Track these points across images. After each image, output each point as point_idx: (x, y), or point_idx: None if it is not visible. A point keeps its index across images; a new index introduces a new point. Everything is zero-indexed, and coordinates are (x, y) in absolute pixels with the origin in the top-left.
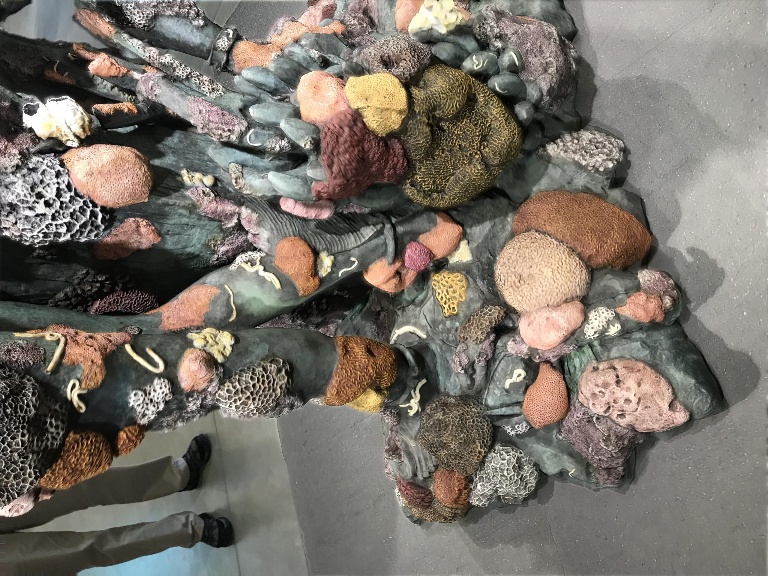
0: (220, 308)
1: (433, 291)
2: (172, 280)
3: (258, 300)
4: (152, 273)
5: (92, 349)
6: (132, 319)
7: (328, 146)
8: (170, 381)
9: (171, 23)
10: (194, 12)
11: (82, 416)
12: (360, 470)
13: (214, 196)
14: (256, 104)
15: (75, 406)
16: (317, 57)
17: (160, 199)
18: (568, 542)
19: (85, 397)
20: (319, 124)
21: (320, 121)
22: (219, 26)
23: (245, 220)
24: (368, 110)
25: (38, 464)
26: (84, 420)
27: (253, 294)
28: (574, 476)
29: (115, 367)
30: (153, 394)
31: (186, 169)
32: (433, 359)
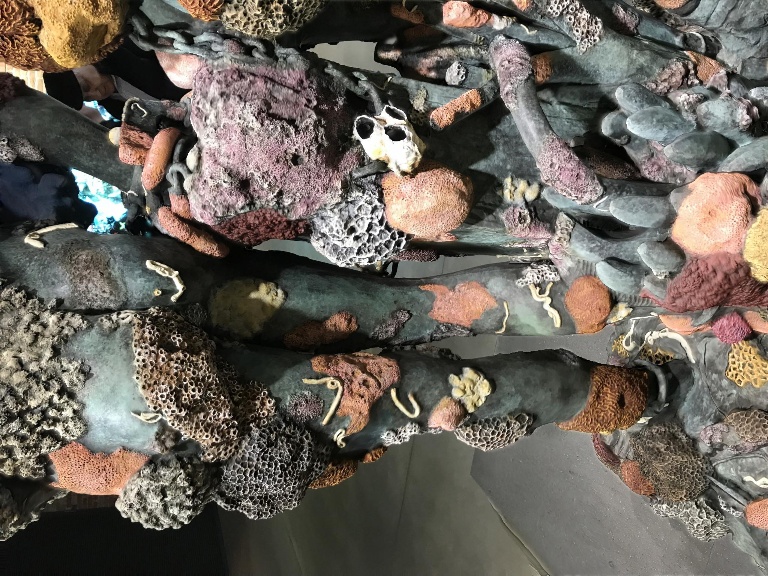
0: (491, 321)
1: (729, 346)
2: (456, 247)
3: (531, 328)
4: (439, 245)
5: (362, 401)
6: (406, 295)
7: (685, 287)
8: (420, 425)
9: None
10: None
11: (341, 449)
12: (570, 347)
13: (530, 222)
14: (623, 200)
15: (338, 445)
16: (743, 124)
17: (470, 226)
18: (721, 569)
19: (347, 438)
20: (689, 253)
21: (693, 251)
22: None
23: (553, 246)
24: (764, 268)
25: (301, 496)
26: (342, 451)
27: (529, 322)
28: (761, 569)
29: (378, 414)
30: (403, 433)
31: (511, 176)
32: (689, 386)
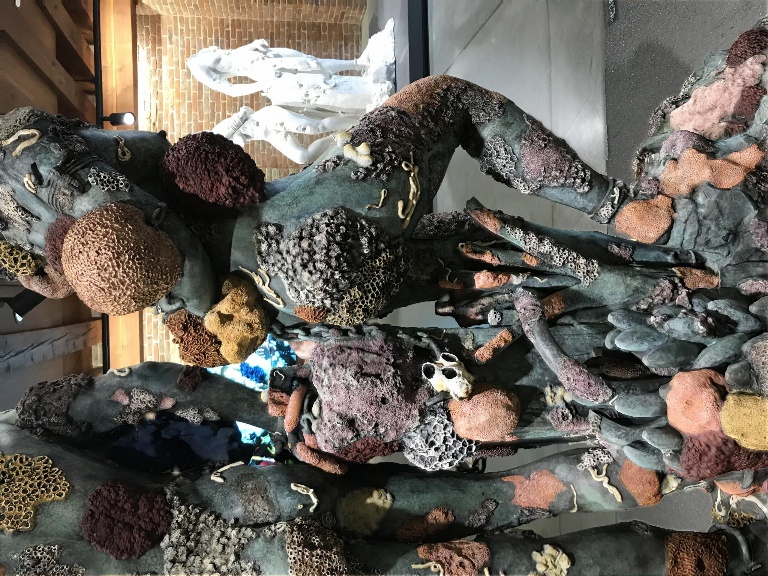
0: (564, 502)
1: None
2: None
3: (599, 504)
4: None
5: None
6: (491, 487)
7: (689, 461)
8: None
9: (555, 191)
10: (580, 180)
11: None
12: (683, 517)
13: (572, 418)
14: (622, 400)
15: None
16: (701, 333)
17: (523, 428)
18: None
19: None
20: (684, 434)
21: (686, 432)
22: (606, 179)
23: None
24: (742, 440)
25: None
26: None
27: (595, 499)
28: None
29: None
30: None
31: (550, 385)
32: None
